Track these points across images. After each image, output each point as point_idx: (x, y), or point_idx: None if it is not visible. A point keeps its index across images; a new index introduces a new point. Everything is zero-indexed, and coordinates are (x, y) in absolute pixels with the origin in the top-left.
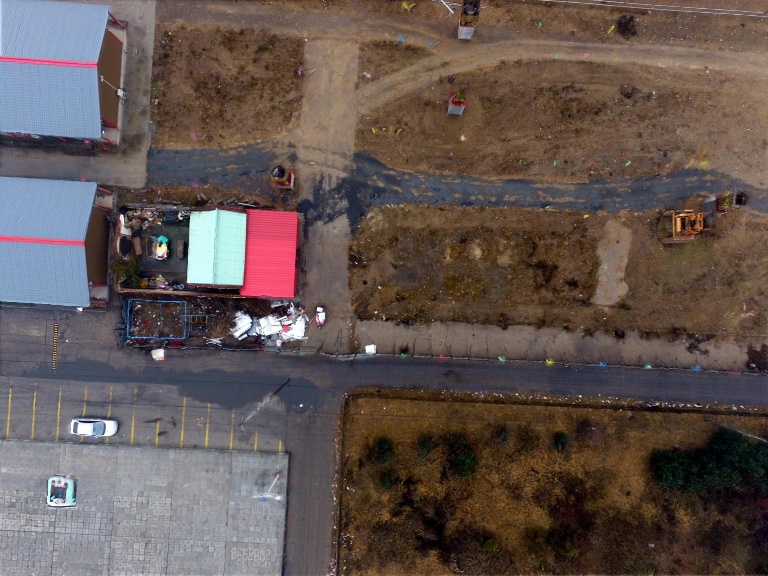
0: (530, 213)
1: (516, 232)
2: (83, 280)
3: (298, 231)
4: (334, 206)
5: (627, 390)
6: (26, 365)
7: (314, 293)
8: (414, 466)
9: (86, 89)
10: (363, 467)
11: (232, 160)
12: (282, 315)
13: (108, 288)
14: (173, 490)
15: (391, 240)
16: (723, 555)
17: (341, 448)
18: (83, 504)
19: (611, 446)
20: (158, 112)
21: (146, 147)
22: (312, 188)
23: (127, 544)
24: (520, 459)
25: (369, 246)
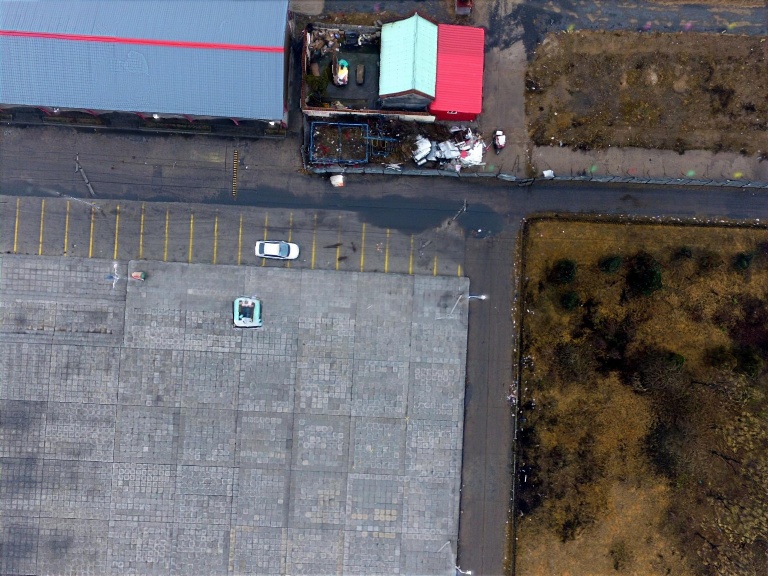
0: (706, 38)
1: (692, 57)
2: (279, 90)
3: None
4: (510, 32)
5: None
6: (207, 191)
7: (491, 119)
8: (593, 289)
9: None
10: (543, 290)
11: None
12: (461, 140)
13: (287, 114)
14: (357, 312)
15: (567, 66)
16: None
17: (520, 272)
18: (268, 325)
19: None
20: None
21: None
22: (488, 14)
23: (312, 364)
24: (699, 281)
25: (545, 72)
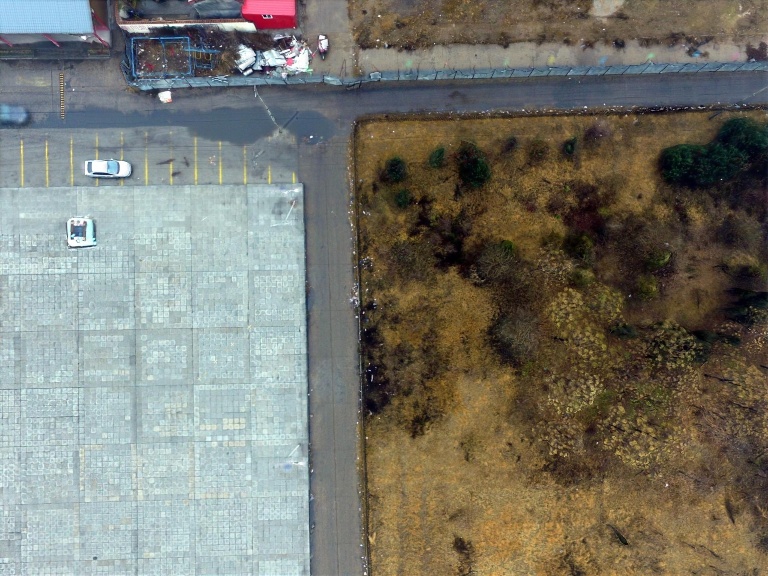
0: None
1: None
2: (85, 2)
3: None
4: None
5: (631, 98)
6: (35, 116)
7: (315, 26)
8: (427, 186)
9: None
10: (377, 191)
11: None
12: (285, 48)
13: (110, 33)
14: (192, 224)
15: None
16: (736, 247)
17: (354, 174)
18: (104, 244)
19: (619, 152)
20: None
21: None
22: None
23: (151, 280)
24: (531, 171)
25: None
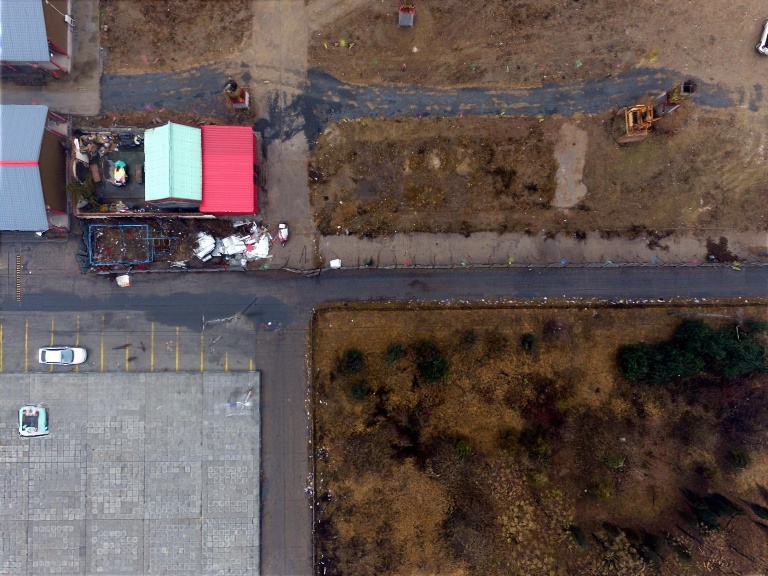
0: (486, 120)
1: (473, 140)
2: (40, 202)
3: (255, 148)
4: (291, 124)
5: (591, 289)
6: None
7: (276, 211)
8: (385, 376)
9: (30, 10)
10: (334, 380)
11: (186, 83)
12: (245, 234)
13: (68, 217)
14: (146, 413)
15: (350, 154)
16: (693, 444)
17: (312, 363)
18: (56, 432)
19: (578, 345)
20: (108, 38)
21: (98, 74)
22: (268, 107)
23: (103, 469)
24: (489, 363)
25: (328, 162)
